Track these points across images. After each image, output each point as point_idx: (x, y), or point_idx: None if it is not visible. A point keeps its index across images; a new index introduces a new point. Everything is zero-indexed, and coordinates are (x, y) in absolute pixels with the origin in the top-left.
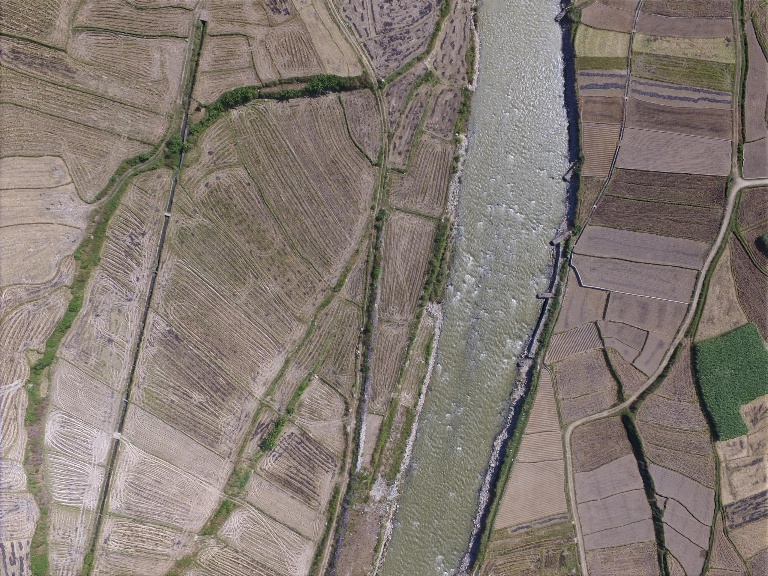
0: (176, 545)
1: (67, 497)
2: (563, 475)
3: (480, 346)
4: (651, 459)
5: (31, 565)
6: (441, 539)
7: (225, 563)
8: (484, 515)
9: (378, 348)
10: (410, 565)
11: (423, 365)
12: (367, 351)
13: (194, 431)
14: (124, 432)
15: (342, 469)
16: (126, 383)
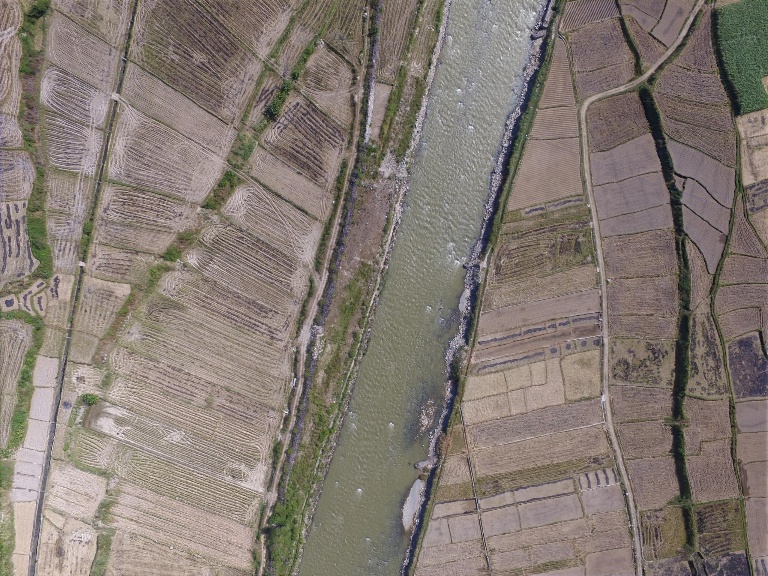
0: (178, 217)
1: (64, 162)
2: (578, 154)
3: (492, 17)
4: (670, 135)
5: (28, 228)
6: (452, 225)
7: (229, 242)
8: (497, 198)
9: (386, 11)
10: (420, 252)
11: (433, 33)
12: (375, 12)
13: (196, 93)
14: (123, 93)
15: (350, 143)
16: (124, 39)
